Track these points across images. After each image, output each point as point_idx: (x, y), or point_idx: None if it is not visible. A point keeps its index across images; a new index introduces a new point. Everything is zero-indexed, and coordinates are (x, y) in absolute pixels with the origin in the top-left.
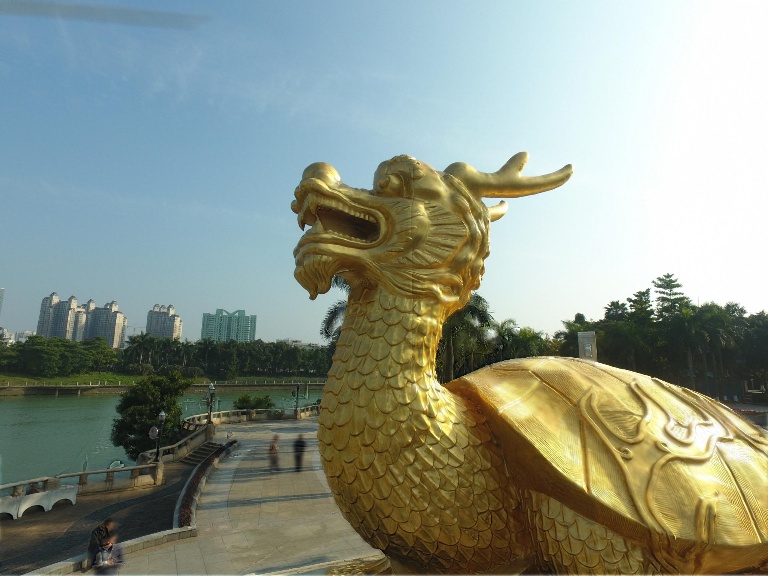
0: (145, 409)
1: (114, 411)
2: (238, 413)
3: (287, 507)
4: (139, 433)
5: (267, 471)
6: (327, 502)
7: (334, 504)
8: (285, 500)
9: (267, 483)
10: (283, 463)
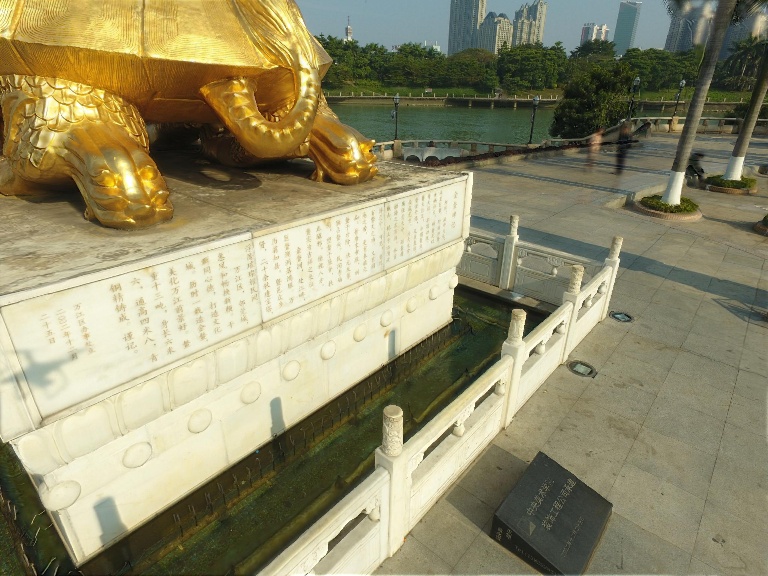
0: (575, 102)
1: (557, 104)
2: (721, 122)
3: (523, 182)
4: (569, 126)
5: (596, 164)
6: (565, 188)
7: (566, 190)
8: (537, 179)
9: (565, 169)
10: (635, 163)
